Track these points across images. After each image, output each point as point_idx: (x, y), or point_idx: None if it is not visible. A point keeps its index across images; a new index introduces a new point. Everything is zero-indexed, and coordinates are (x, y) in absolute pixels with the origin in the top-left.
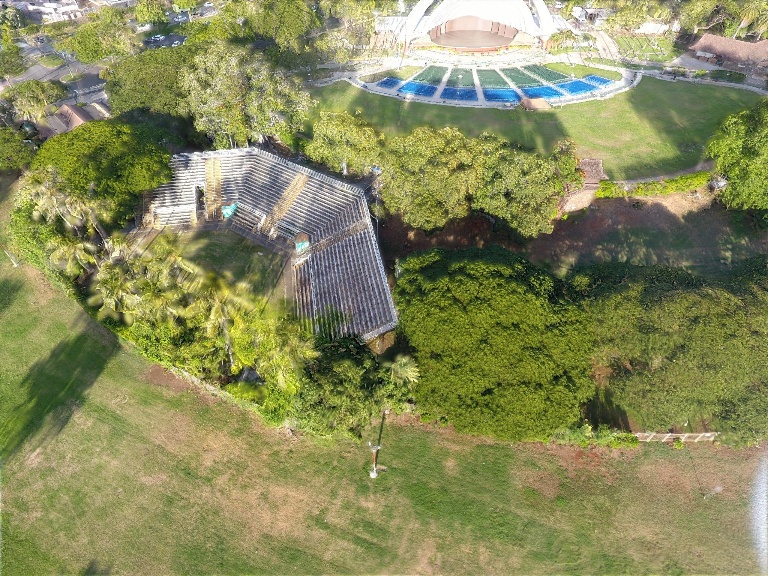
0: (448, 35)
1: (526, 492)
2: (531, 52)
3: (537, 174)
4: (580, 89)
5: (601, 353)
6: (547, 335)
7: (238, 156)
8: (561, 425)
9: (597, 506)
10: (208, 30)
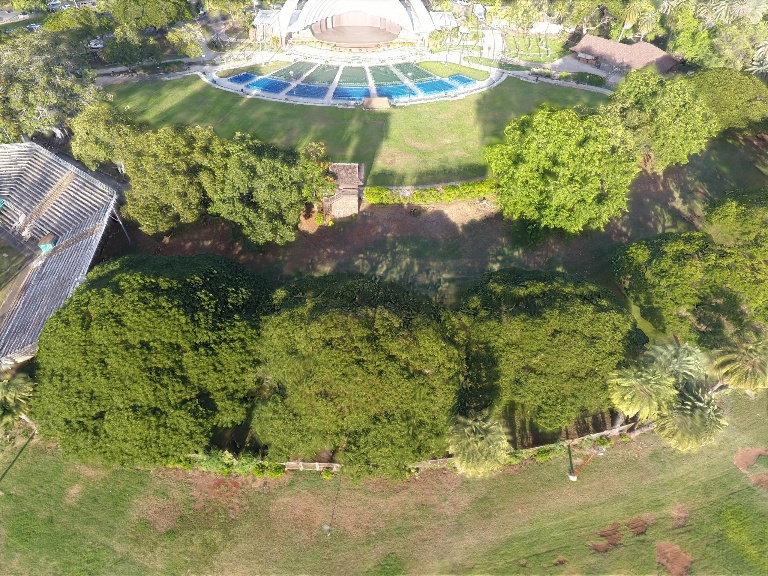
0: (334, 30)
1: (138, 524)
2: (412, 49)
3: (272, 177)
4: (435, 89)
5: (254, 374)
6: (188, 353)
7: (16, 151)
8: (174, 453)
9: (206, 542)
10: (59, 19)
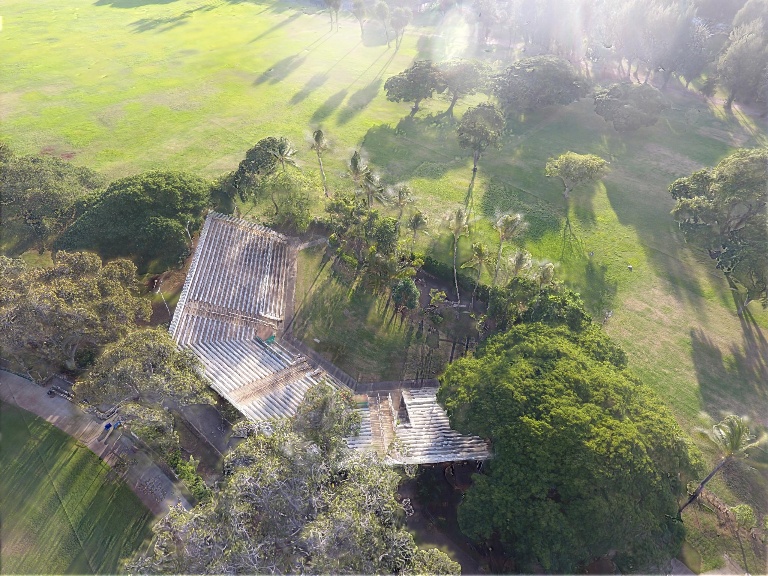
0: None
1: None
2: None
3: None
4: None
5: None
6: None
7: None
8: None
9: None
10: None
